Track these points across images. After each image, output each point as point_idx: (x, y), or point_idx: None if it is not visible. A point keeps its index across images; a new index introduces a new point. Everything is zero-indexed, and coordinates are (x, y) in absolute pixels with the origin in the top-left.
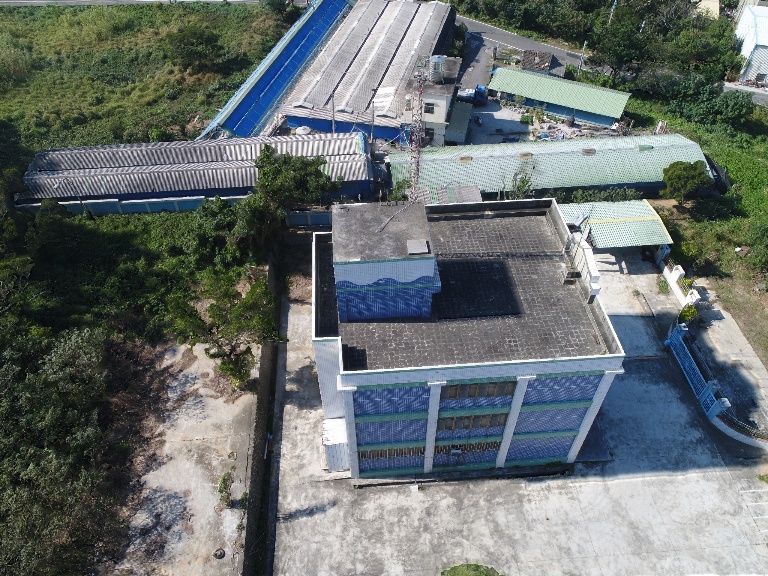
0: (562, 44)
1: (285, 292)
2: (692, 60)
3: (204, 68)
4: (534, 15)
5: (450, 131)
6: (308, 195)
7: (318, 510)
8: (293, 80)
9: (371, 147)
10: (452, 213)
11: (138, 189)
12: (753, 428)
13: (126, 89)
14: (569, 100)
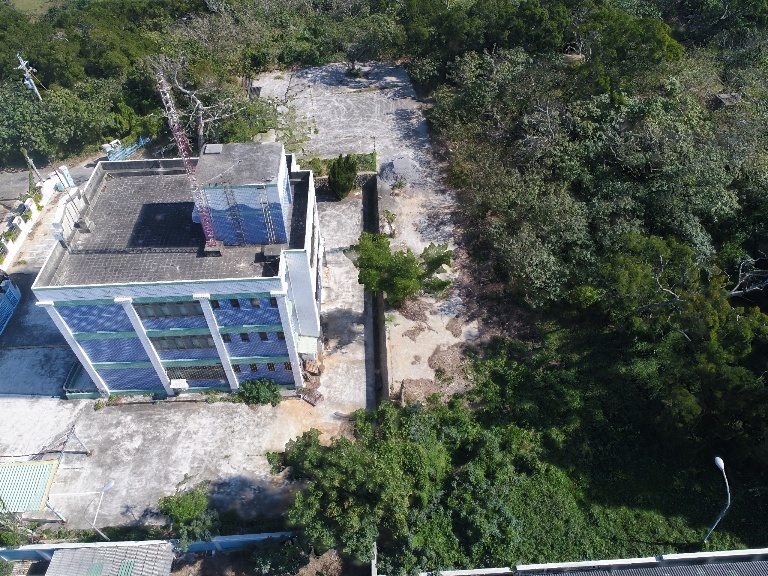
0: None
1: None
2: None
3: None
4: None
5: None
6: None
7: (336, 250)
8: None
9: None
10: None
11: (639, 575)
12: (3, 271)
13: None
14: None
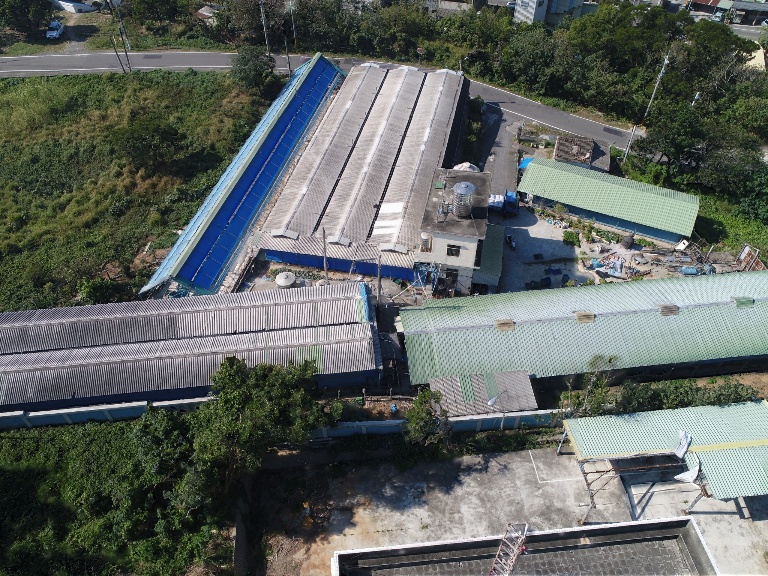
0: (595, 115)
1: (261, 567)
2: (767, 148)
3: (160, 168)
4: (560, 79)
5: (480, 273)
6: (291, 434)
7: None
8: (272, 190)
9: (377, 304)
10: (526, 544)
11: (52, 394)
12: None
13: (60, 201)
14: (622, 209)
